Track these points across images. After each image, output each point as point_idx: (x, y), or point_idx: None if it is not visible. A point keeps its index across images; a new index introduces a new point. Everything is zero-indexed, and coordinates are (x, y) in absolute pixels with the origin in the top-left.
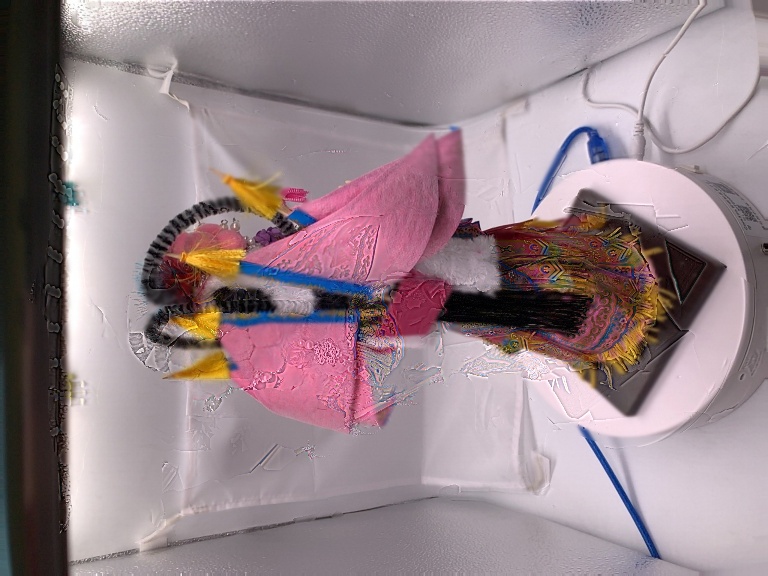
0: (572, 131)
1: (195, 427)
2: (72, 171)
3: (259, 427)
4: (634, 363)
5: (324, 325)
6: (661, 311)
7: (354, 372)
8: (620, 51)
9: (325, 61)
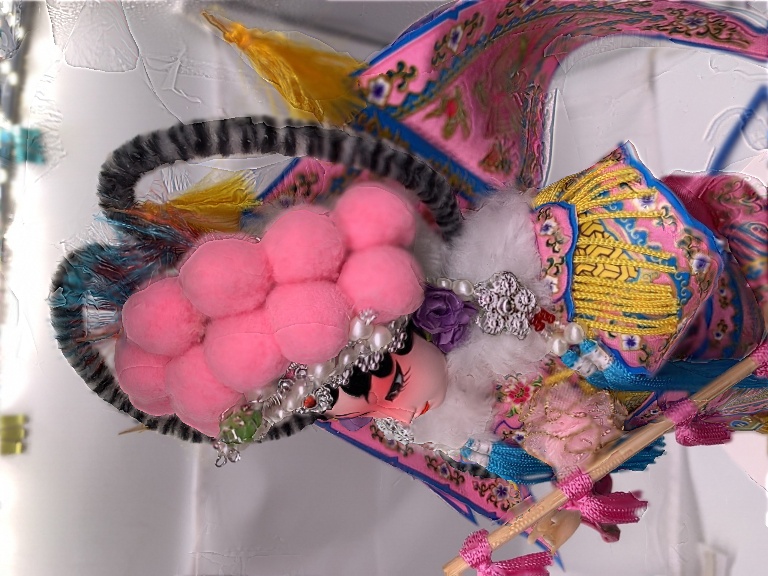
0: (715, 118)
1: (206, 572)
2: (2, 105)
3: (318, 570)
4: None
5: (491, 244)
6: None
7: (571, 352)
8: (762, 11)
9: (382, 36)
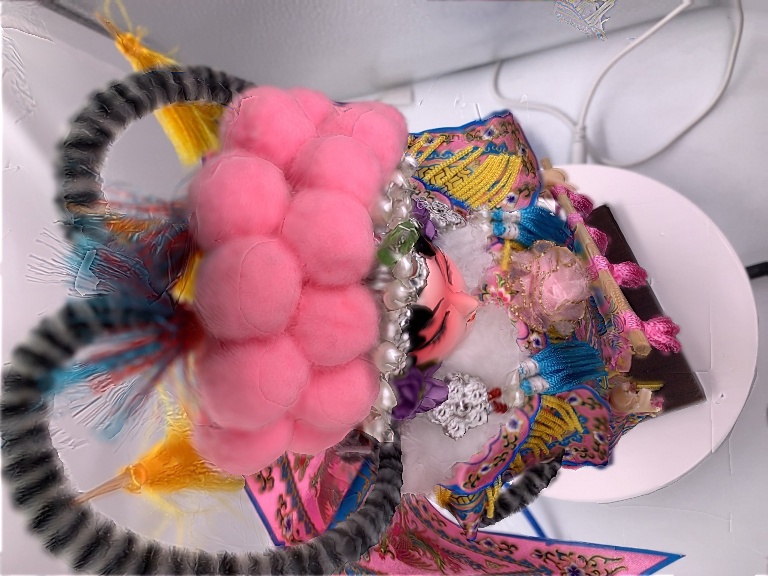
0: None
1: None
2: None
3: None
4: (612, 1)
5: None
6: None
7: (495, 223)
8: None
9: None
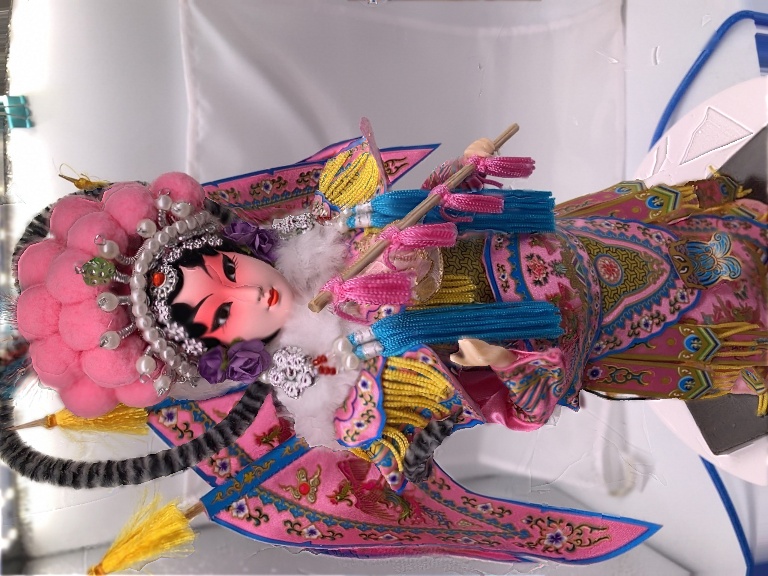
0: None
1: None
2: None
3: None
4: None
5: None
6: (748, 148)
7: (350, 217)
8: None
9: None
